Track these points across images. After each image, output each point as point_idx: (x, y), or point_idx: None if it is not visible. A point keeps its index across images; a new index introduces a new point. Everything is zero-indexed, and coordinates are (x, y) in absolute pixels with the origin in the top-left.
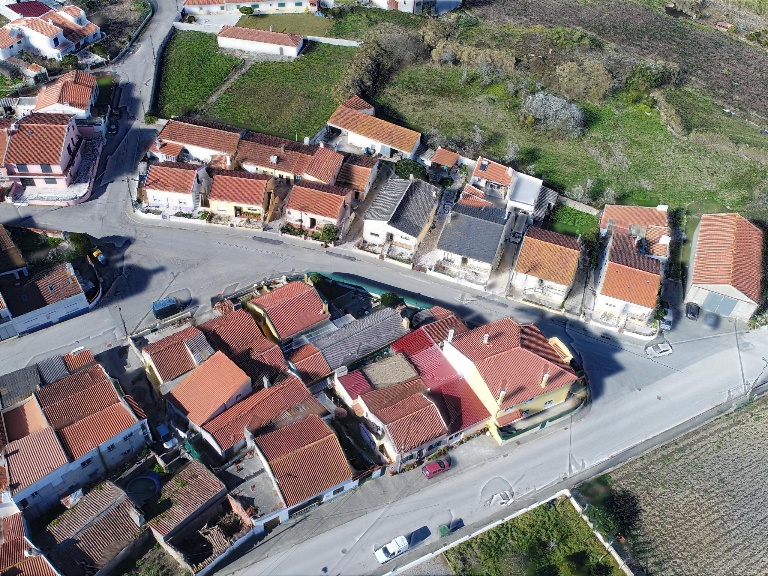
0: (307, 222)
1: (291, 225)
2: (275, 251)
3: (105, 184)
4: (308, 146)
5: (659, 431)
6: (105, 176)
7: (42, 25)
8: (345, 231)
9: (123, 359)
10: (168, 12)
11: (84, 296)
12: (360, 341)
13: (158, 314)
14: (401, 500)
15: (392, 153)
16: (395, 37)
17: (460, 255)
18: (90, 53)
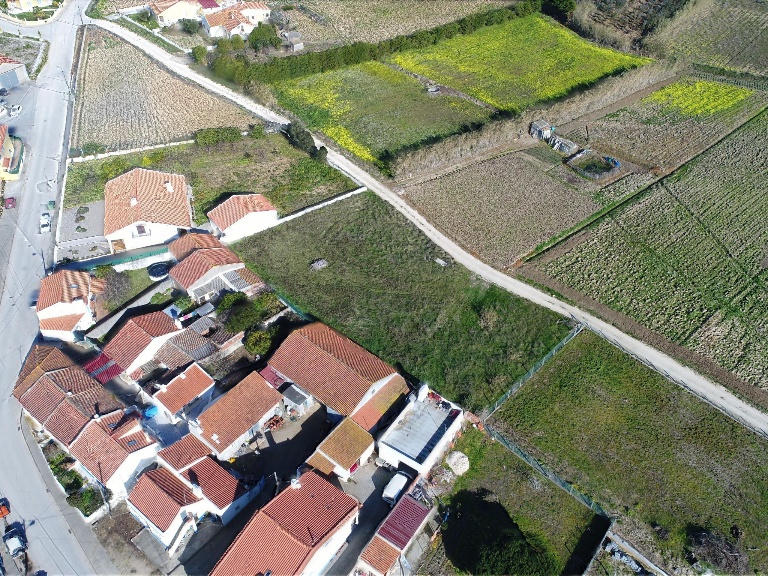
0: None
1: None
2: None
3: None
4: None
5: (64, 127)
6: None
7: None
8: None
9: None
10: None
11: None
12: None
13: None
14: (18, 221)
15: None
16: None
17: None
18: None
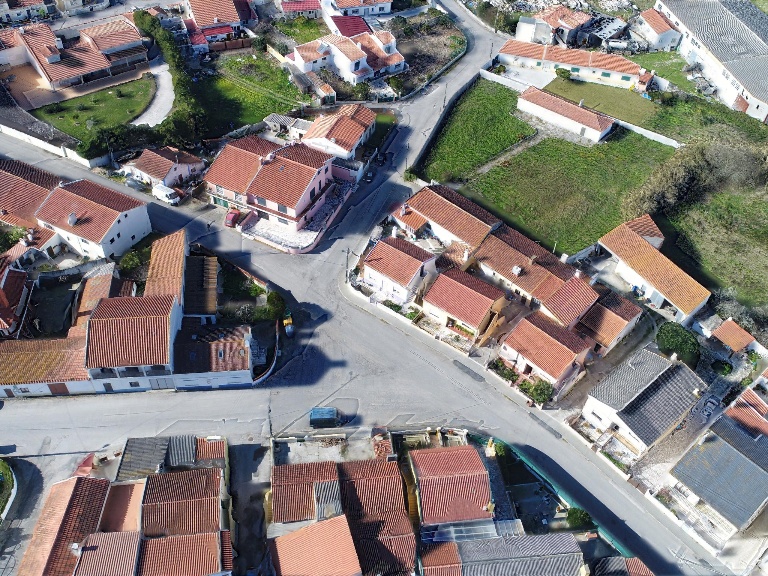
0: (522, 366)
1: (503, 361)
2: (471, 388)
3: (334, 238)
4: (563, 264)
5: None
6: (338, 229)
7: (350, 46)
8: (564, 392)
9: (256, 463)
10: (481, 55)
11: (250, 373)
12: (516, 570)
13: (313, 422)
14: None
15: (664, 304)
16: (727, 150)
17: (698, 496)
18: (385, 84)
